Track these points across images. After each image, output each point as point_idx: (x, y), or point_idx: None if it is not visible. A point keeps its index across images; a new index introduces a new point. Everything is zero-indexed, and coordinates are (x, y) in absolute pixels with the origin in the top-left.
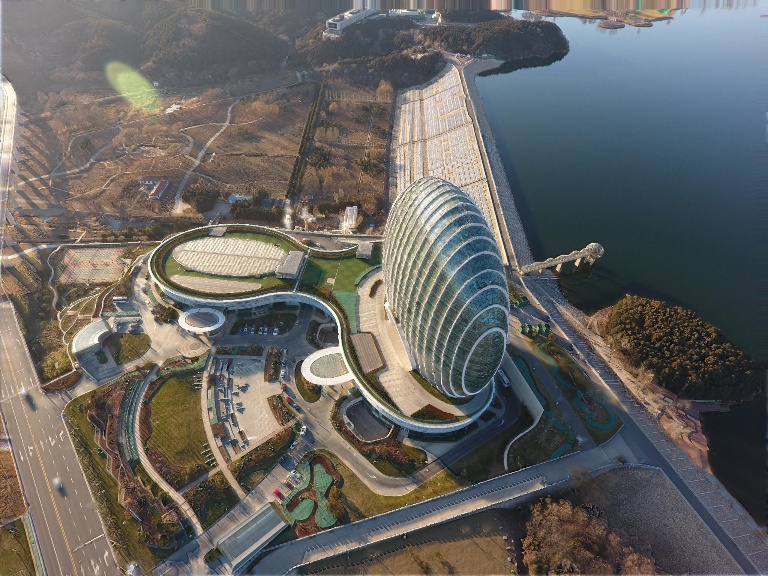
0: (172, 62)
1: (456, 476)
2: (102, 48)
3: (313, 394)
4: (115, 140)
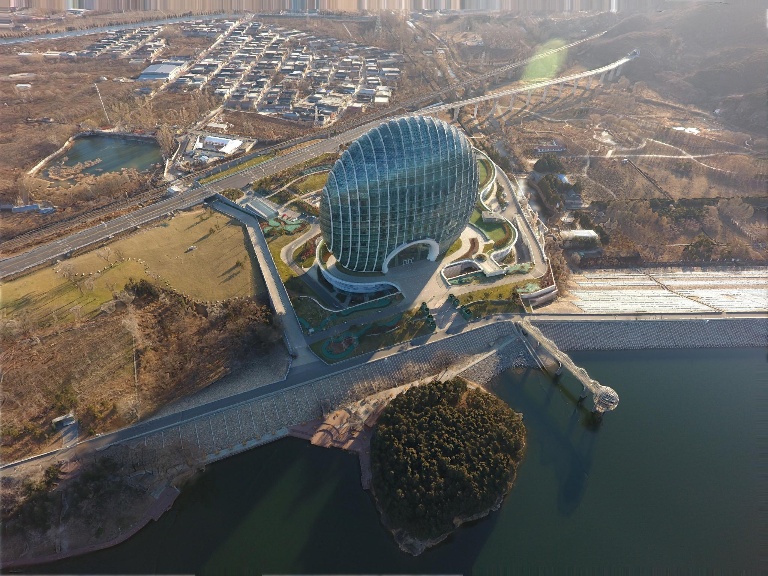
0: (755, 101)
1: None
2: (725, 70)
3: None
4: (593, 116)
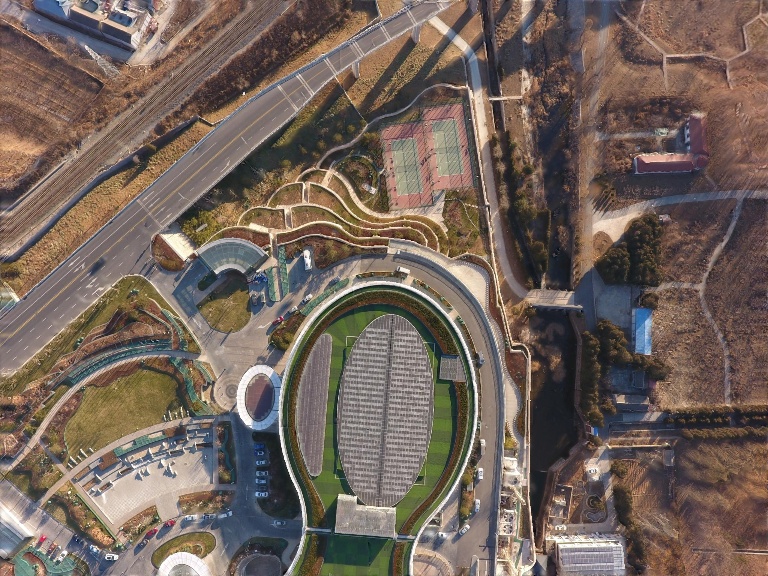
0: None
1: None
2: None
3: None
4: None
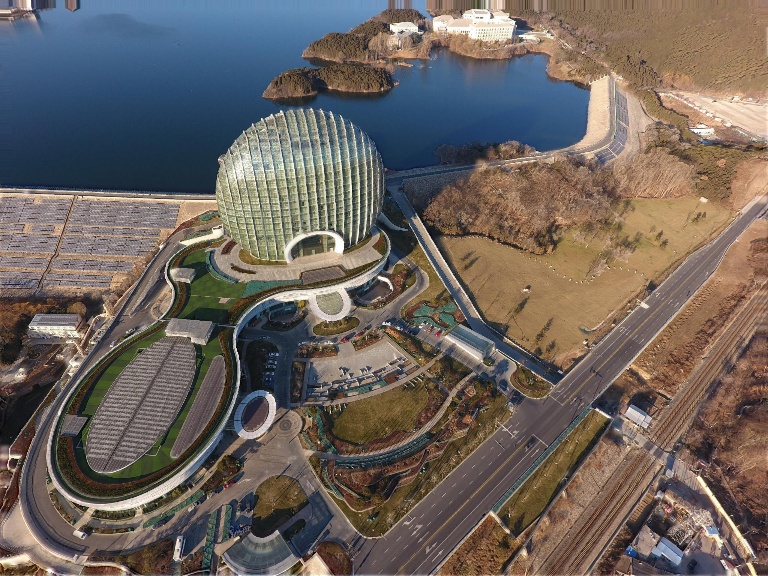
0: None
1: (413, 251)
2: None
3: (351, 321)
4: None
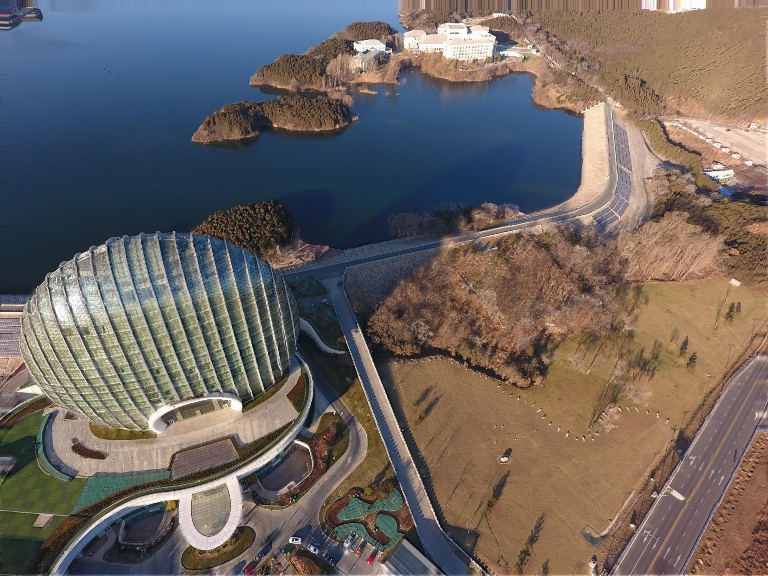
0: None
1: (349, 390)
2: None
3: (243, 536)
4: None
